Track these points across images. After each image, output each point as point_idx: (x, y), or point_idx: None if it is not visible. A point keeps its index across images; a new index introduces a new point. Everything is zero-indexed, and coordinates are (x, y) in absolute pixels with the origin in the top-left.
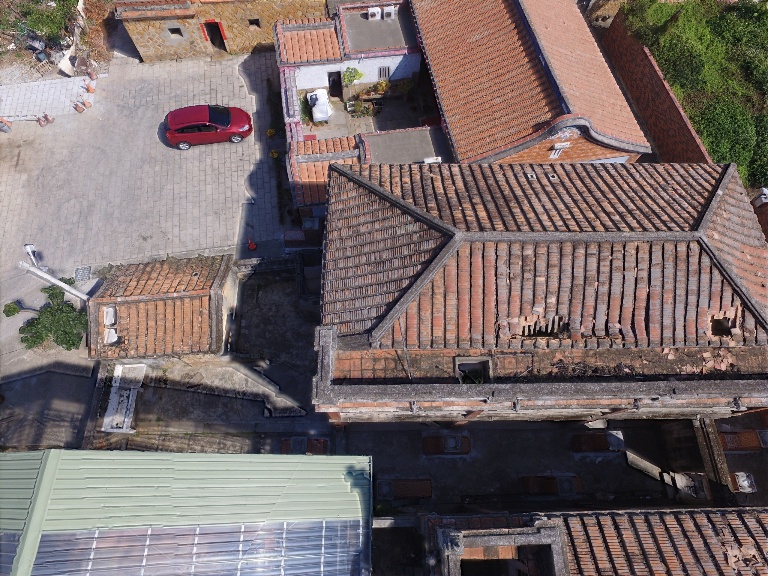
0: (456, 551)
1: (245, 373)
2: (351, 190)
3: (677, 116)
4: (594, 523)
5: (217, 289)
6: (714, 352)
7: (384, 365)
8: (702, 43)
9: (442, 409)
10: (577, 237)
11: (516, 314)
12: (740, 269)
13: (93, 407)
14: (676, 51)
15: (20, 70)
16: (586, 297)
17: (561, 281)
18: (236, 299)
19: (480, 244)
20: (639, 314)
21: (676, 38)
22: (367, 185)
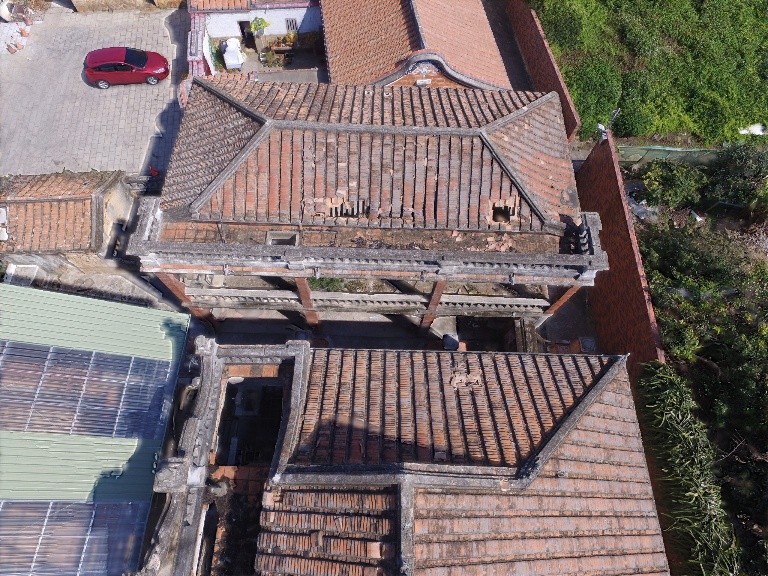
0: (197, 344)
1: (133, 281)
2: (204, 97)
3: (552, 71)
4: (351, 355)
5: (99, 194)
6: (498, 237)
7: (205, 235)
8: (587, 9)
9: (252, 274)
10: (374, 128)
11: (321, 195)
12: (527, 168)
13: None
14: (559, 14)
15: None
16: (383, 182)
17: (360, 167)
18: (129, 214)
19: (289, 131)
20: (429, 199)
21: (560, 3)
22: (215, 91)
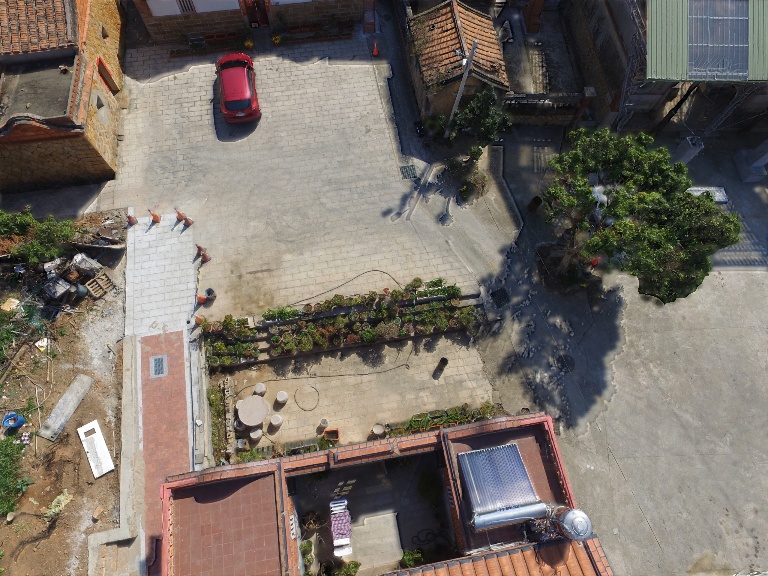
0: None
1: None
2: None
3: None
4: None
5: None
6: None
7: None
8: None
9: None
10: None
11: None
12: None
13: (541, 95)
14: None
15: (94, 323)
16: None
17: None
18: None
19: None
20: None
21: None
22: None
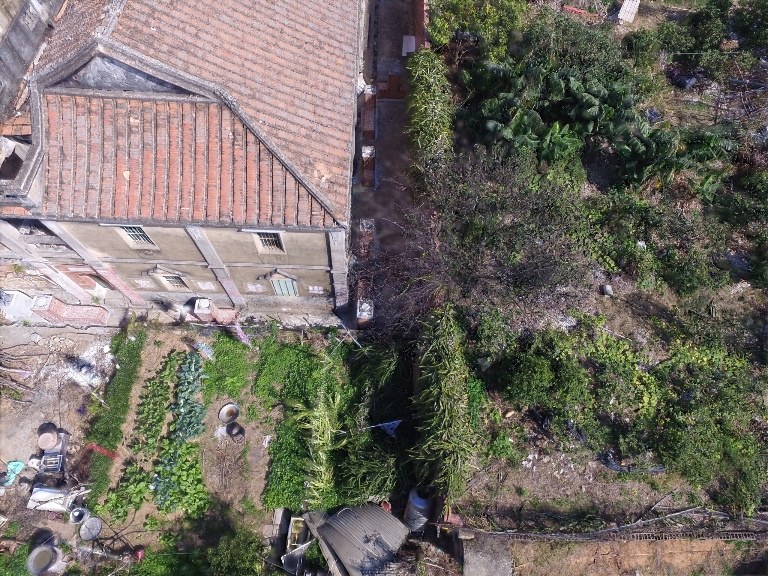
0: None
1: None
2: None
3: None
4: None
5: None
6: None
7: None
8: None
9: None
10: None
11: None
12: None
13: None
14: None
15: None
16: None
17: None
18: None
19: None
20: None
21: None
22: None
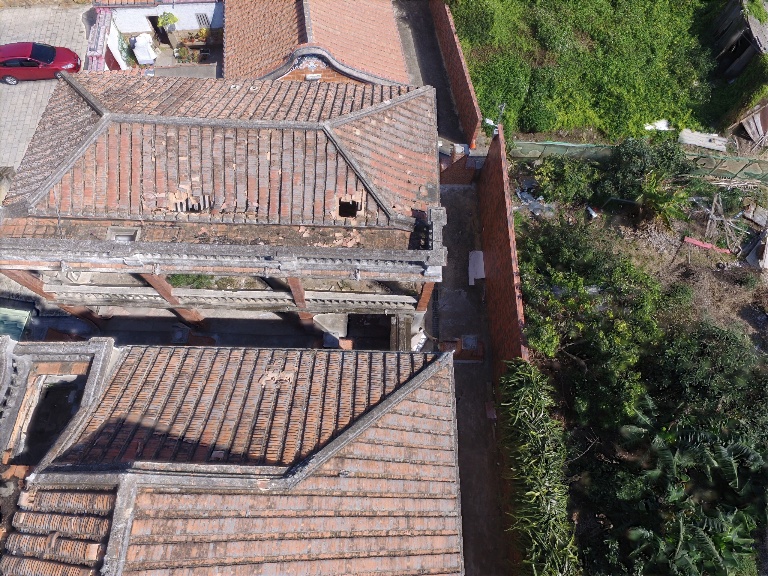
0: None
1: None
2: (65, 91)
3: (460, 66)
4: (167, 352)
5: None
6: (346, 233)
7: (44, 231)
8: (503, 4)
9: (90, 270)
10: (214, 122)
11: (163, 190)
12: (380, 163)
13: None
14: (471, 9)
15: None
16: (226, 177)
17: (202, 161)
18: None
19: (128, 125)
20: (274, 194)
21: None
22: (73, 85)
